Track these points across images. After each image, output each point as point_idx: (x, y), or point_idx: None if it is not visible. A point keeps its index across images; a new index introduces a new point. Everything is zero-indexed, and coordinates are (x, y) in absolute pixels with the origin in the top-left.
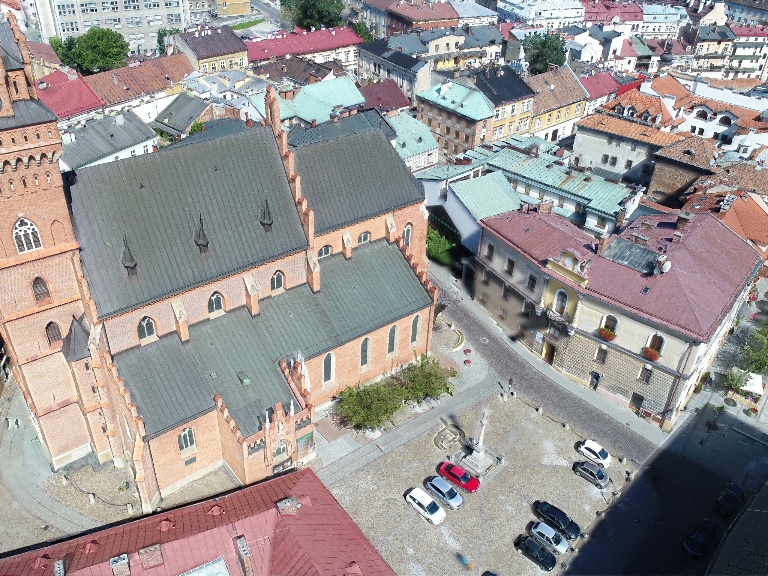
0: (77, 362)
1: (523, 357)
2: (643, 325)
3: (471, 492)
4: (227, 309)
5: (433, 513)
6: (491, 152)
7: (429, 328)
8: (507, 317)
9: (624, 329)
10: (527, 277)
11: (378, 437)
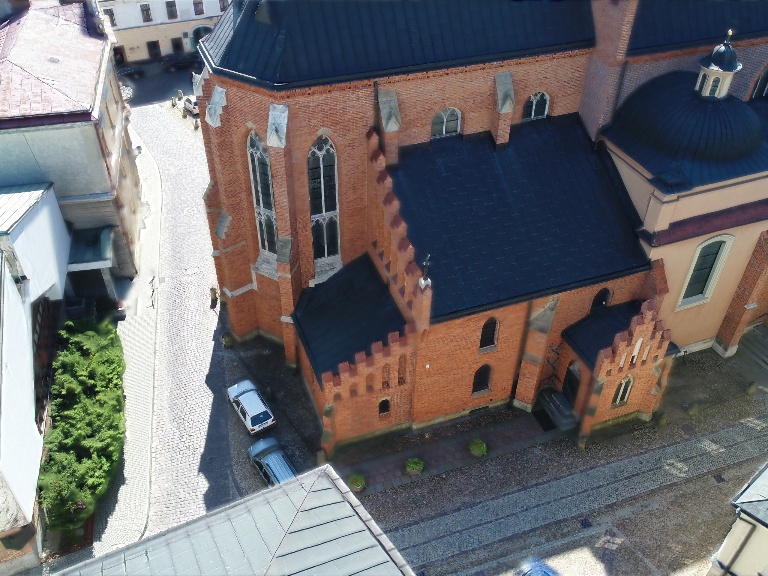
0: None
1: None
2: None
3: None
4: None
5: None
6: None
7: None
8: None
9: None
10: None
11: None
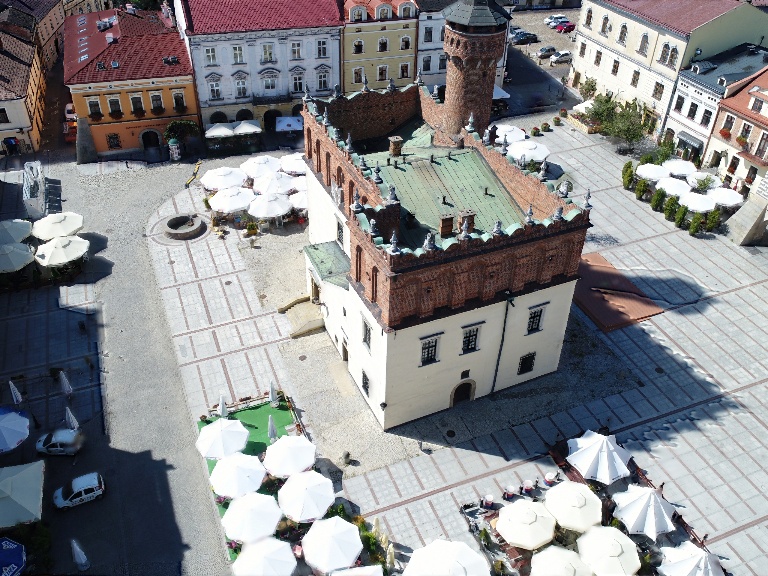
0: None
1: None
2: None
3: None
4: None
5: None
6: None
7: None
8: None
9: None
10: None
11: None
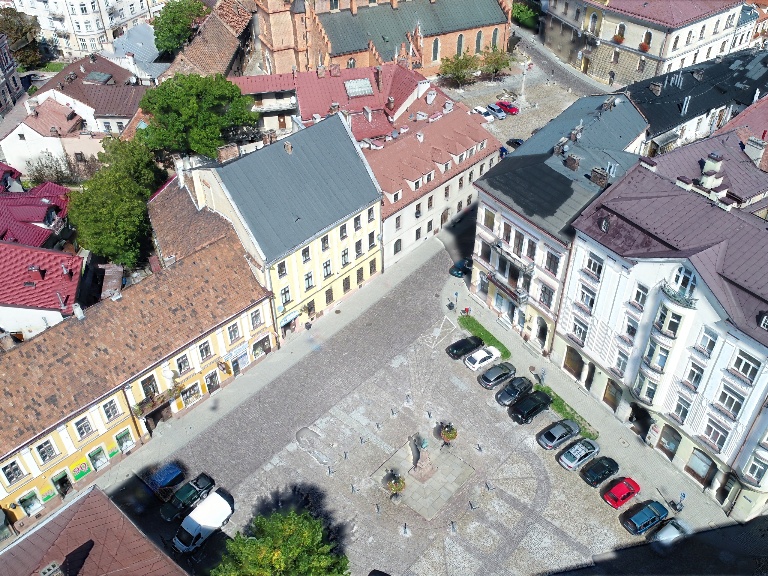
0: (298, 15)
1: (568, 70)
2: (640, 26)
3: (512, 113)
4: (379, 2)
5: (487, 116)
6: None
7: (505, 42)
8: (563, 48)
9: (629, 32)
10: (575, 11)
11: (462, 92)
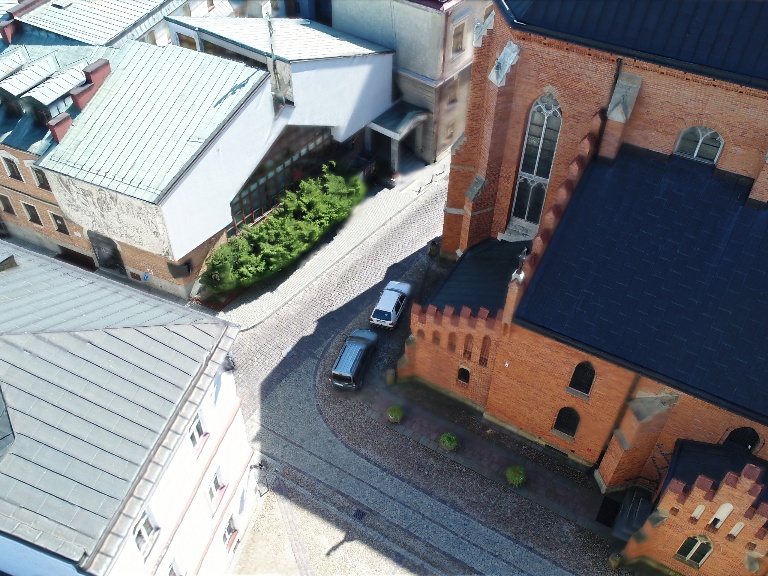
0: None
1: None
2: None
3: None
4: None
5: None
6: (10, 57)
7: None
8: None
9: None
10: None
11: None
